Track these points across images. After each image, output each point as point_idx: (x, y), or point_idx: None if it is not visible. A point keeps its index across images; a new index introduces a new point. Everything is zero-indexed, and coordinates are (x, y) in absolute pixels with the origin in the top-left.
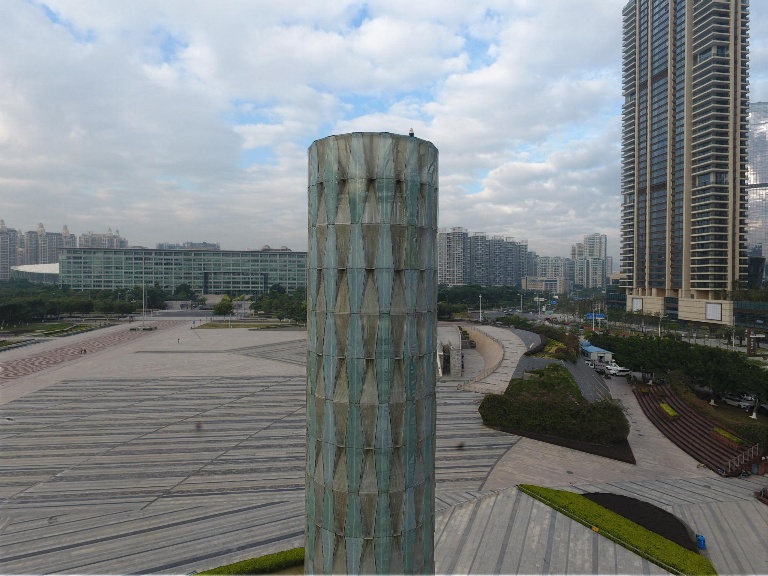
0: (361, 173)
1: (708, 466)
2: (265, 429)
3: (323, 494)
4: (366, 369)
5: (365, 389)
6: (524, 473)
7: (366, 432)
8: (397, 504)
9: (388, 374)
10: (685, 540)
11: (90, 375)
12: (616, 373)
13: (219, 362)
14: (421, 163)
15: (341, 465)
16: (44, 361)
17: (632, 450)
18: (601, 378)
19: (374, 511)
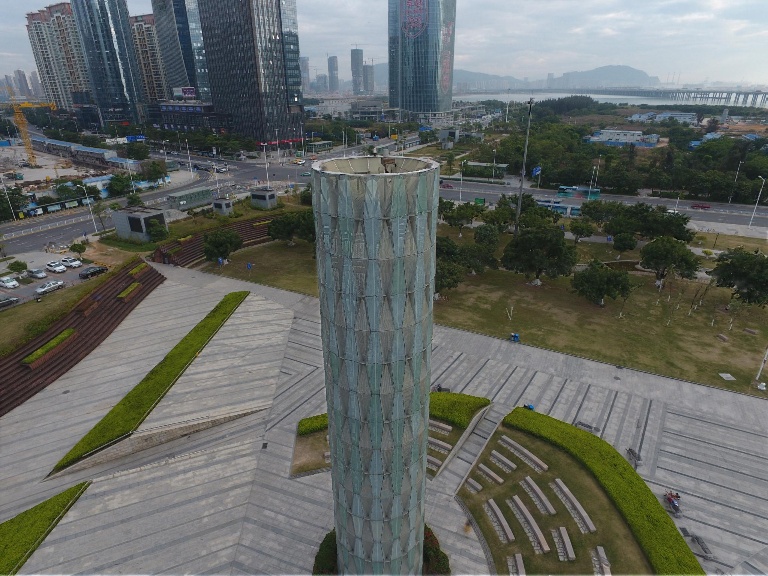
0: None
1: None
2: None
3: None
4: None
5: None
6: None
7: None
8: None
9: None
10: None
11: None
12: None
13: None
14: None
15: None
16: None
17: None
18: None
19: None
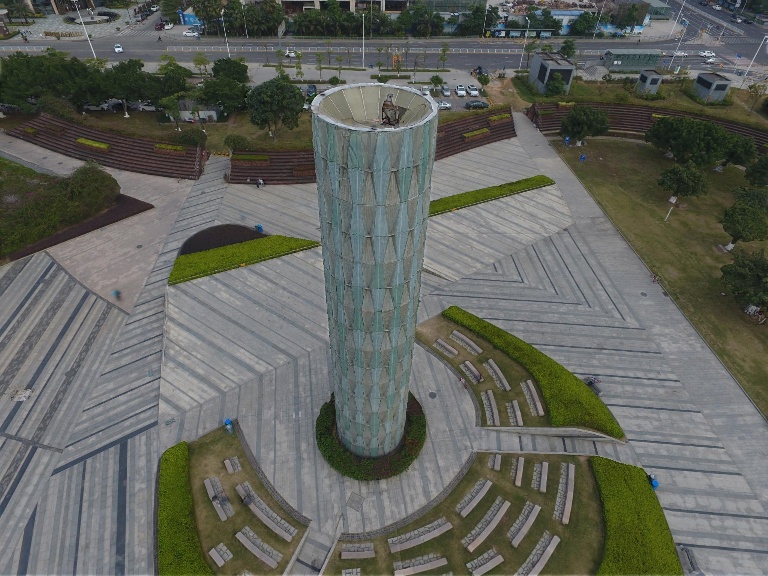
0: (434, 145)
1: (181, 177)
2: None
3: None
4: None
5: None
6: (120, 275)
7: None
8: None
9: None
10: (256, 233)
11: None
12: None
13: None
14: None
15: None
16: None
17: None
18: None
19: None
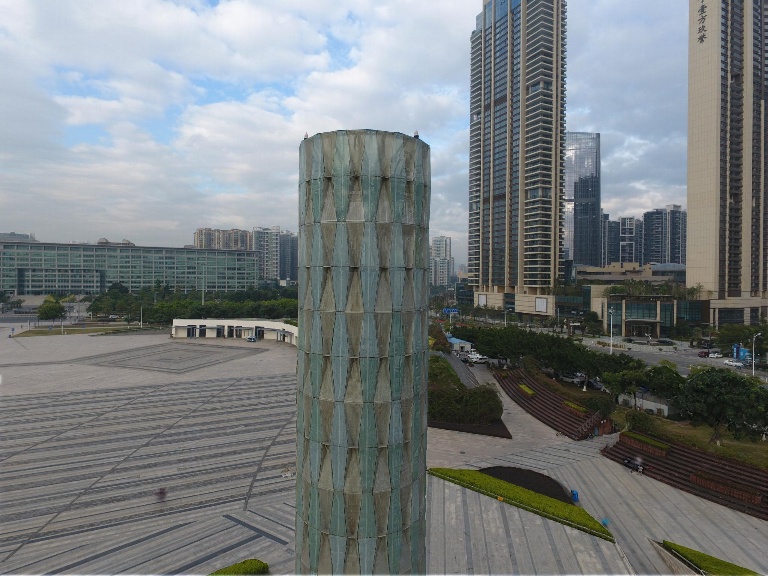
0: (374, 171)
1: (564, 433)
2: (144, 446)
3: (332, 499)
4: (379, 368)
5: (378, 388)
6: None
7: (379, 430)
8: (405, 498)
9: (399, 371)
10: (564, 496)
11: None
12: (477, 361)
13: (61, 375)
14: (422, 165)
15: (352, 467)
16: None
17: (506, 427)
18: (466, 366)
19: (387, 508)
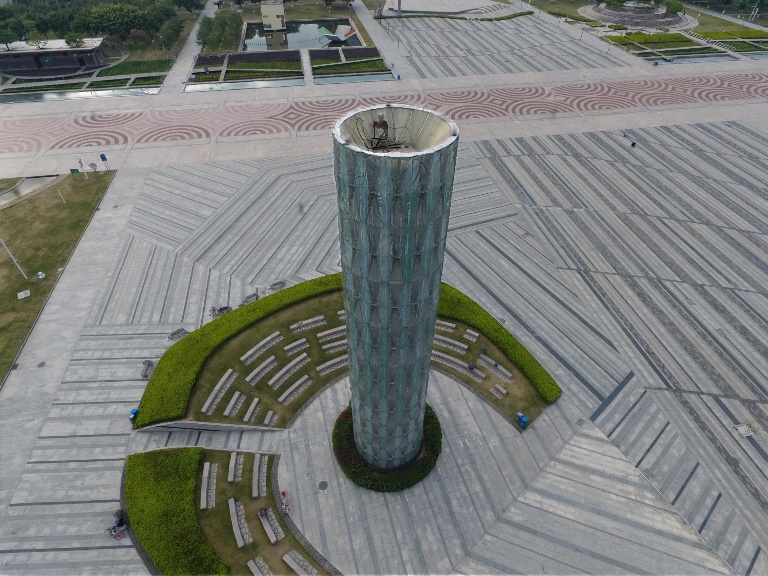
0: None
1: None
2: (765, 295)
3: None
4: None
5: None
6: None
7: None
8: None
9: None
10: None
11: (766, 125)
12: None
13: None
14: None
15: None
16: (766, 86)
17: None
18: None
19: None
